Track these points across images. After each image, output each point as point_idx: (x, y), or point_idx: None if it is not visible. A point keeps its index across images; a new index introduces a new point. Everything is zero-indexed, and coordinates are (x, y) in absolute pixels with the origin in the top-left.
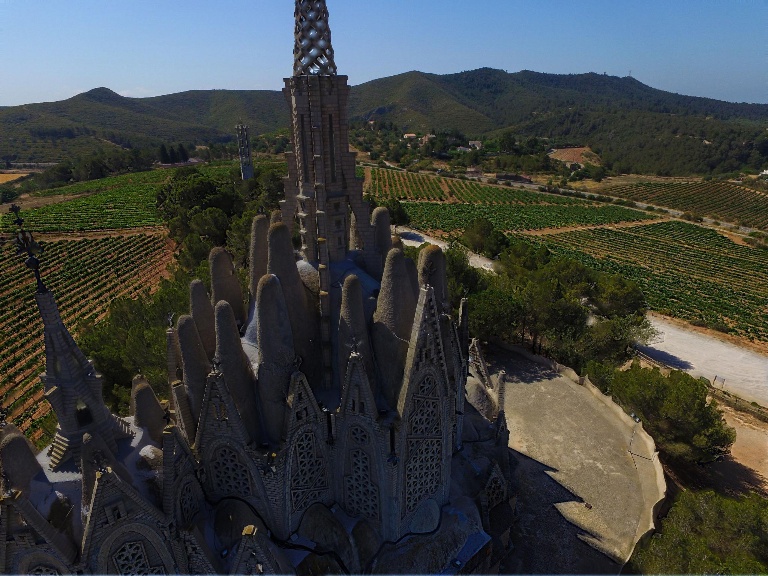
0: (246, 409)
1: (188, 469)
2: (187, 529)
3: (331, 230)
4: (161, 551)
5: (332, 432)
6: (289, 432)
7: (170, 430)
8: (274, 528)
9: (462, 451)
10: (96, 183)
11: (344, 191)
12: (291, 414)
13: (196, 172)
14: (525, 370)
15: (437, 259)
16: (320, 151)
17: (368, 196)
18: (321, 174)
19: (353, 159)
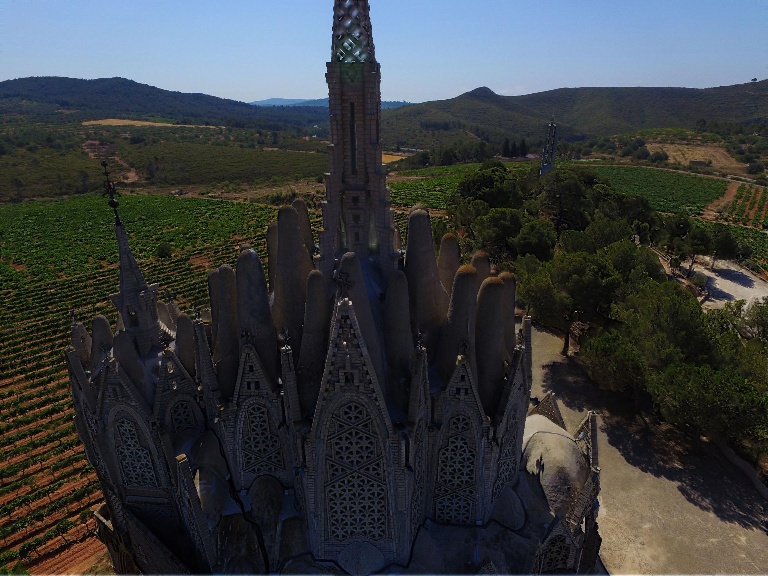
0: (227, 362)
1: (188, 390)
2: (159, 432)
3: (349, 224)
4: (148, 439)
5: (286, 417)
6: (236, 395)
7: (166, 352)
8: (232, 475)
9: (482, 529)
10: (442, 169)
11: (366, 185)
12: (238, 380)
13: (500, 166)
14: (735, 501)
15: (464, 284)
16: (337, 141)
17: (681, 215)
18: (333, 164)
19: (374, 152)
